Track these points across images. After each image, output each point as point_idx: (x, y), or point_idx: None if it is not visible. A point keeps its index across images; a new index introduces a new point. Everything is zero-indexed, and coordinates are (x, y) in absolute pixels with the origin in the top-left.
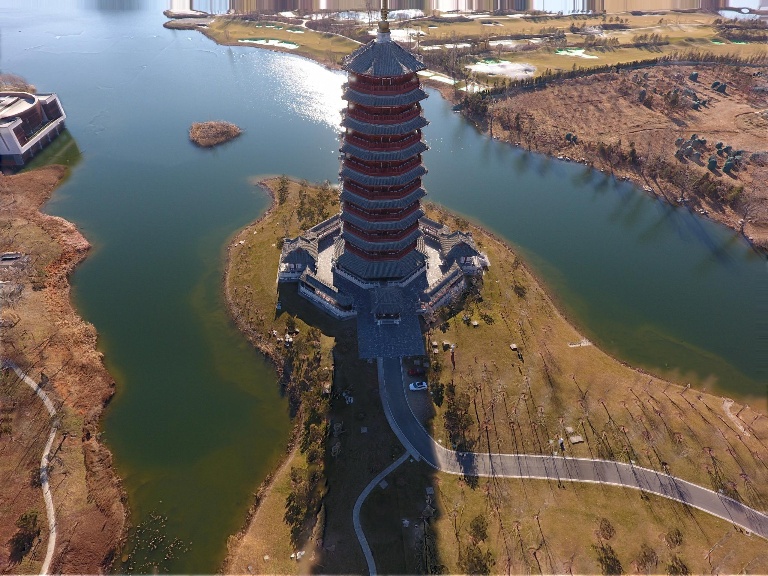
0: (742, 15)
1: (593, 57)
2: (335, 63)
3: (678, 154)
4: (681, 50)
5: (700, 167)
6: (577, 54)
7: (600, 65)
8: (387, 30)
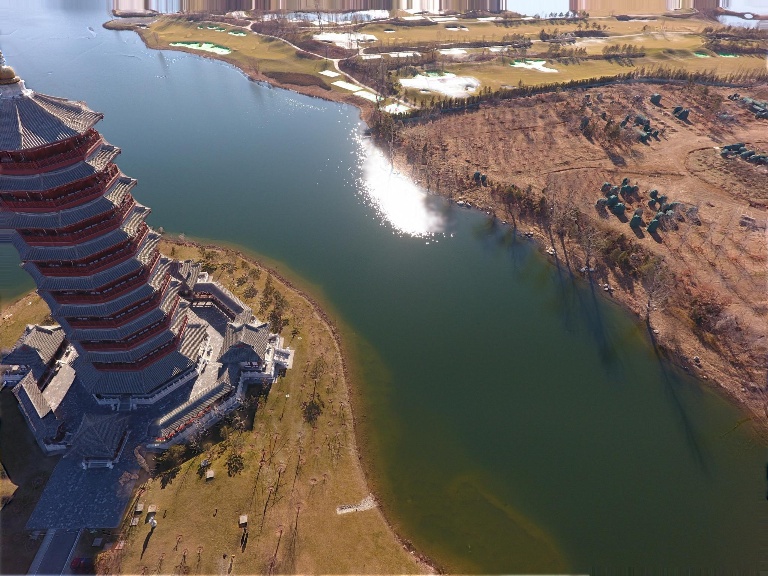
0: (737, 23)
1: (552, 71)
2: (258, 73)
3: (599, 205)
4: (648, 66)
5: (621, 223)
6: (535, 67)
7: (555, 81)
8: (8, 81)
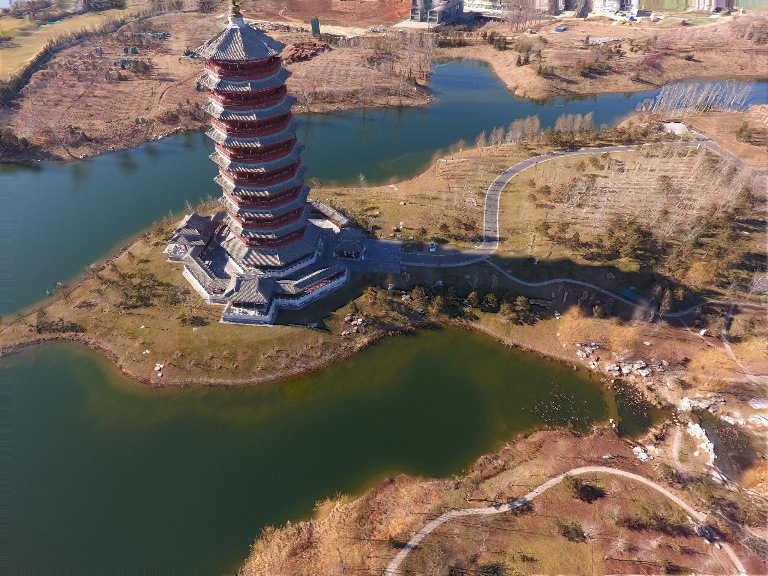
0: None
1: None
2: None
3: None
4: (54, 35)
5: None
6: None
7: None
8: None
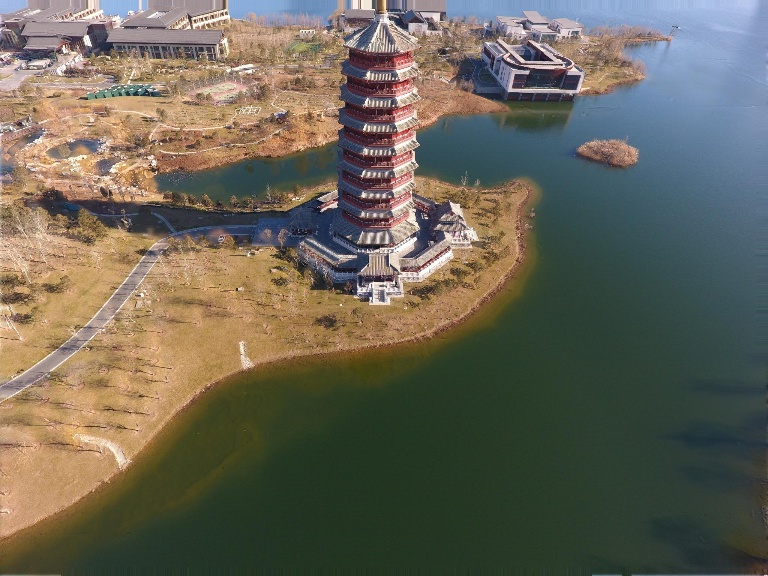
0: None
1: None
2: None
3: None
4: None
5: None
6: None
7: None
8: (378, 11)
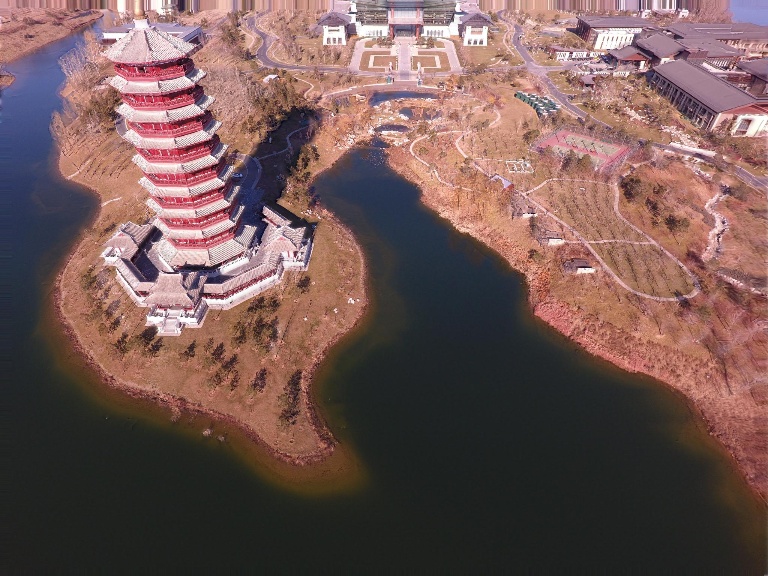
0: None
1: None
2: None
3: None
4: None
5: None
6: None
7: None
8: None
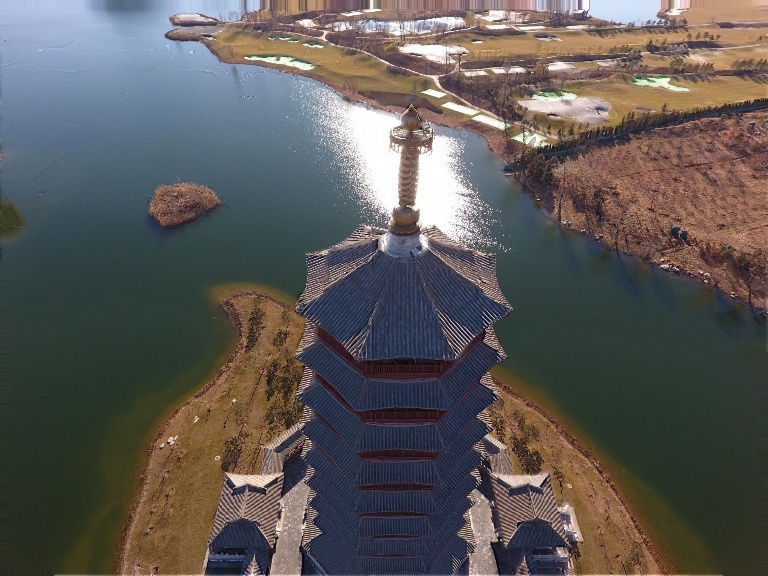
0: None
1: (683, 90)
2: (355, 93)
3: None
4: None
5: None
6: (661, 85)
7: (695, 103)
8: (412, 229)
